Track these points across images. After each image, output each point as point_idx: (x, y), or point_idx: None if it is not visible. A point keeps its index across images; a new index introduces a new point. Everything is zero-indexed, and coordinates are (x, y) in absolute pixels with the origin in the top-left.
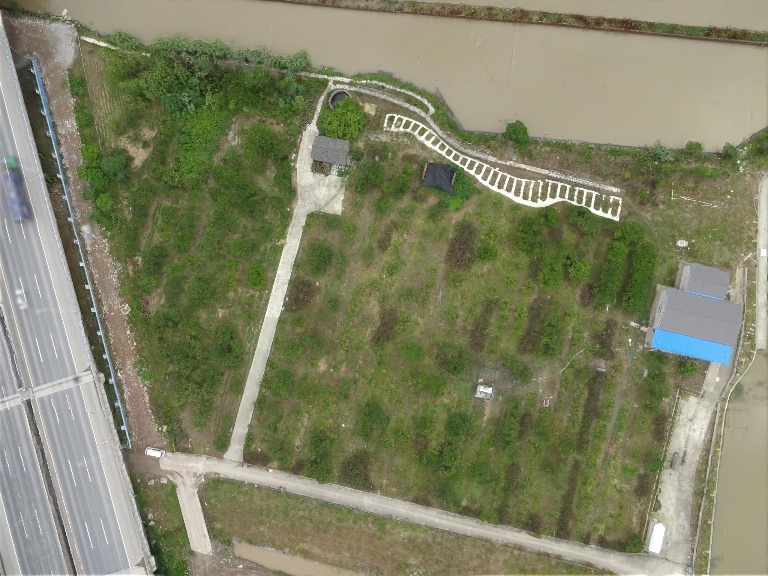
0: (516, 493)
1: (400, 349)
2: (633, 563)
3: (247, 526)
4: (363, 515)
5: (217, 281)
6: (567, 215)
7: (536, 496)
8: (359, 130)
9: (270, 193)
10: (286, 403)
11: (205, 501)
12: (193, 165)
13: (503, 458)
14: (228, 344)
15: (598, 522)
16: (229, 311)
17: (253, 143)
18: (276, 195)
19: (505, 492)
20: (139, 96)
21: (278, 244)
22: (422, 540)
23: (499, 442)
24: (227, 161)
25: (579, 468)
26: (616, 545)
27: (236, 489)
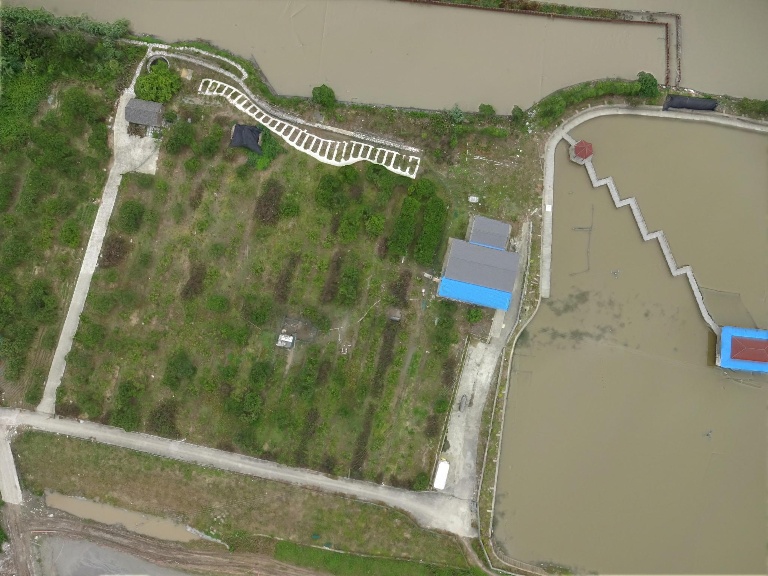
0: (314, 437)
1: (206, 301)
2: (423, 501)
3: (59, 476)
4: (170, 462)
5: (33, 239)
6: (365, 173)
7: (333, 439)
8: (173, 93)
9: (87, 154)
10: (97, 355)
11: (18, 453)
12: (12, 127)
13: (303, 404)
14: (40, 299)
15: (390, 462)
16: (45, 268)
17: (69, 105)
18: (93, 156)
19: (304, 436)
20: None
21: (94, 203)
22: (226, 485)
23: (296, 388)
24: (45, 123)
25: (373, 412)
26: (405, 483)
27: (48, 440)
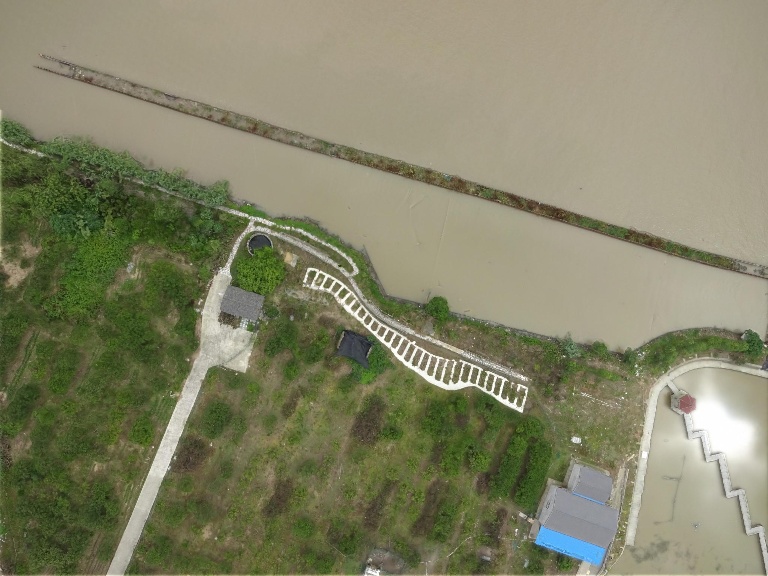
0: None
1: (292, 525)
2: None
3: None
4: None
5: (96, 432)
6: (475, 403)
7: None
8: (276, 284)
9: (169, 339)
10: (161, 573)
11: None
12: (81, 296)
13: None
14: (102, 506)
15: None
16: (107, 465)
17: (155, 284)
18: (176, 342)
19: None
20: (23, 207)
21: (172, 396)
22: None
23: None
24: (123, 298)
25: None
26: None
27: None
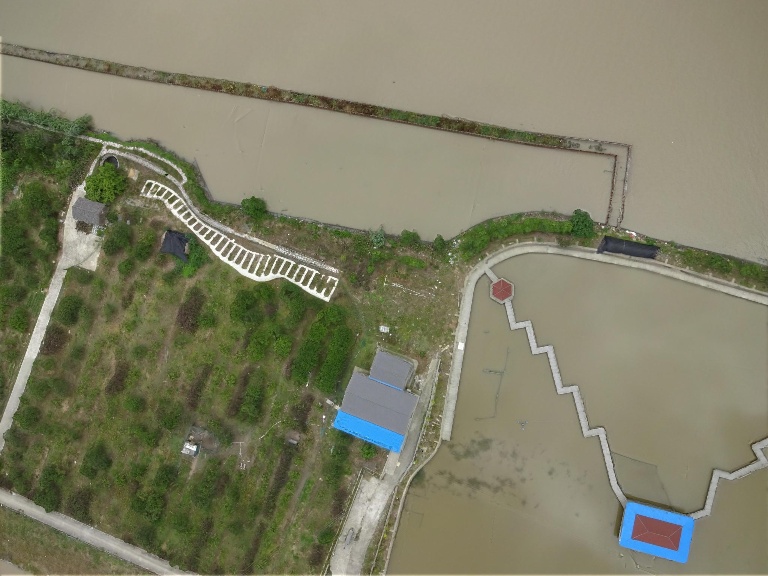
0: (207, 545)
1: None
2: None
3: None
4: (82, 544)
5: None
6: None
7: (223, 550)
8: (117, 194)
9: (41, 245)
10: (30, 436)
11: None
12: None
13: (200, 511)
14: None
15: None
16: None
17: (27, 200)
18: None
19: (197, 543)
20: None
21: (42, 292)
22: (127, 574)
23: (192, 497)
24: None
25: (263, 530)
26: None
27: None
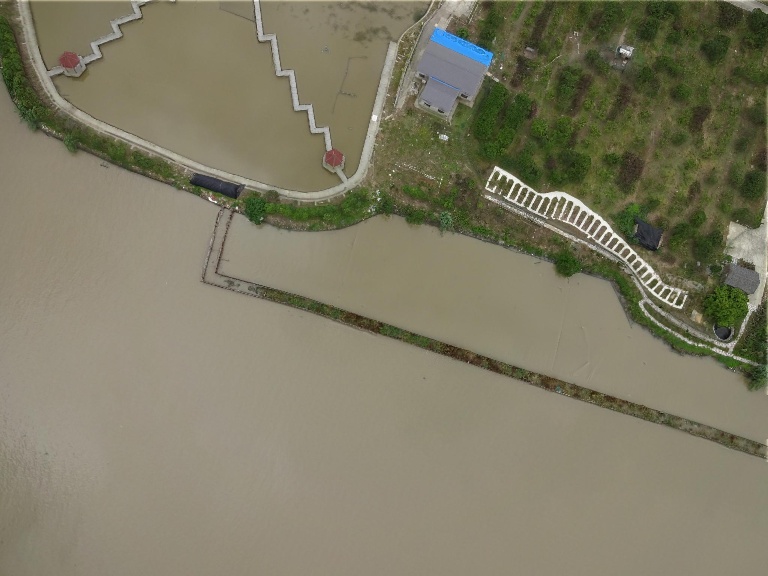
0: None
1: None
2: None
3: None
4: None
5: None
6: None
7: None
8: None
9: None
10: None
11: None
12: None
13: None
14: None
15: None
16: None
17: None
18: None
19: None
20: None
21: None
22: None
23: None
24: None
25: None
26: None
27: None
